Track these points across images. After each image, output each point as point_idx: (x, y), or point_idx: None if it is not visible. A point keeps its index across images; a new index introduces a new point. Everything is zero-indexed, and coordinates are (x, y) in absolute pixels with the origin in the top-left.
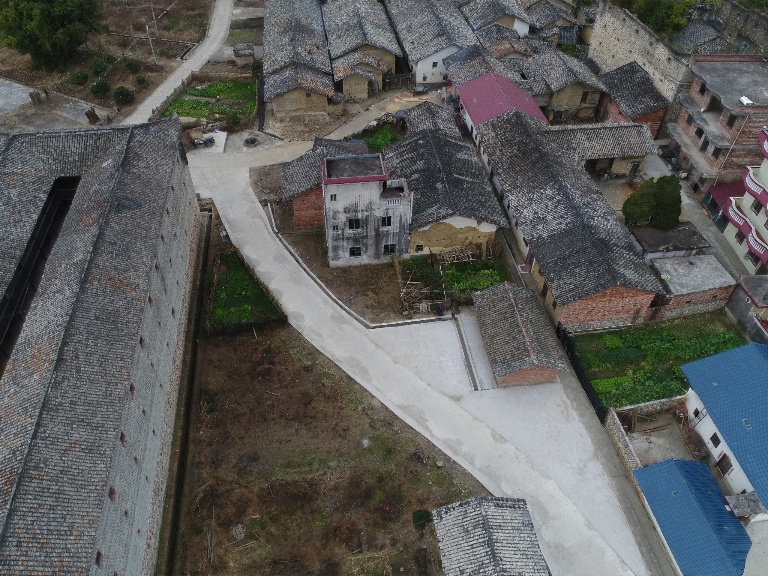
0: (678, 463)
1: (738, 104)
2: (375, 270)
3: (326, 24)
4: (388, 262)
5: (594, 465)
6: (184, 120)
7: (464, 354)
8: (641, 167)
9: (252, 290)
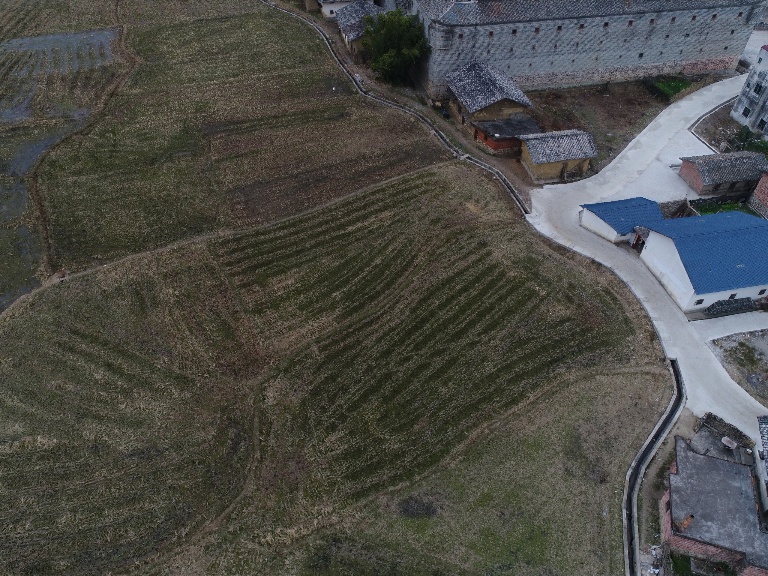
0: (655, 204)
1: None
2: None
3: None
4: None
5: None
6: None
7: None
8: None
9: None
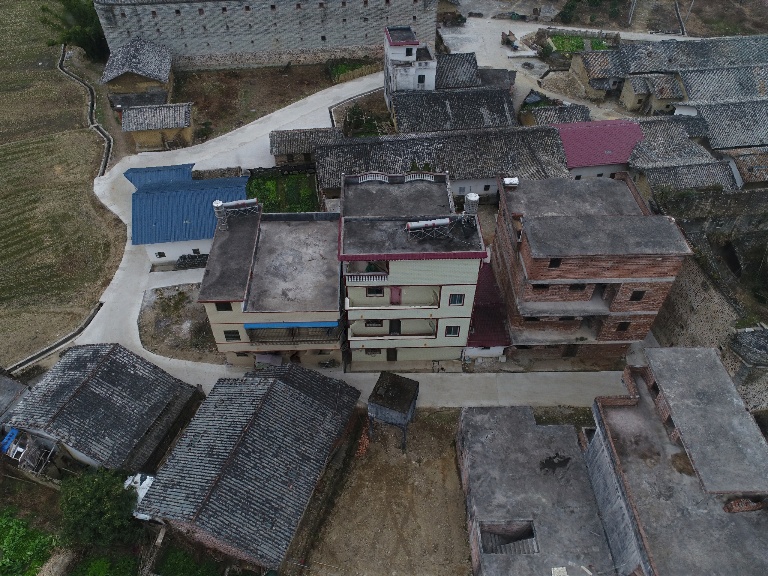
0: (189, 169)
1: None
2: None
3: None
4: None
5: None
6: (549, 41)
7: None
8: None
9: None
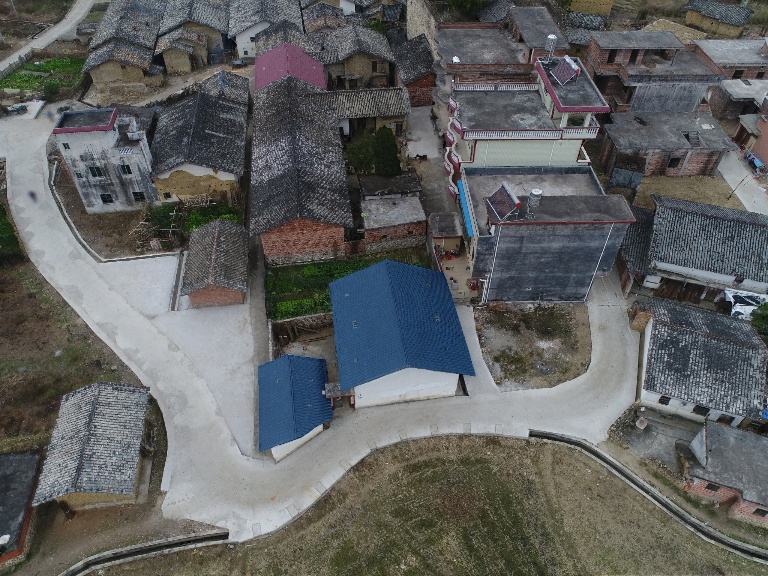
0: (291, 357)
1: (446, 63)
2: (128, 216)
3: (167, 5)
4: (142, 209)
5: (247, 367)
6: (10, 91)
7: (175, 282)
8: (405, 127)
9: (8, 233)
